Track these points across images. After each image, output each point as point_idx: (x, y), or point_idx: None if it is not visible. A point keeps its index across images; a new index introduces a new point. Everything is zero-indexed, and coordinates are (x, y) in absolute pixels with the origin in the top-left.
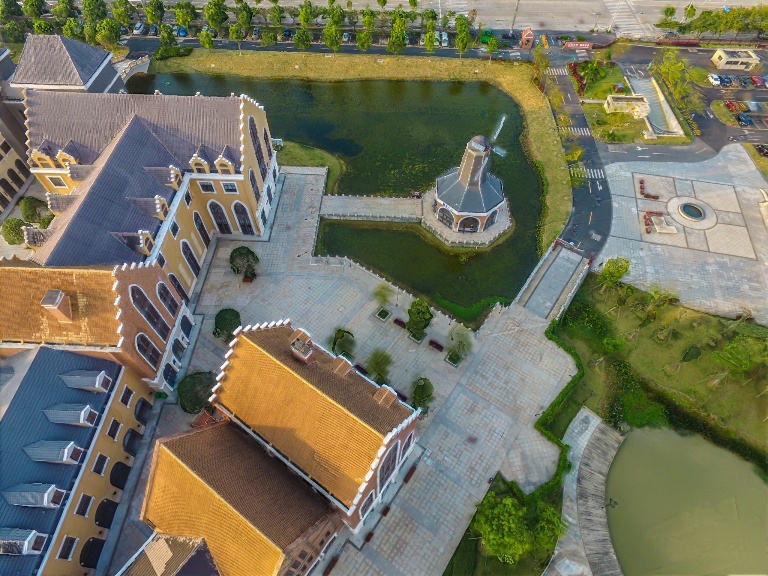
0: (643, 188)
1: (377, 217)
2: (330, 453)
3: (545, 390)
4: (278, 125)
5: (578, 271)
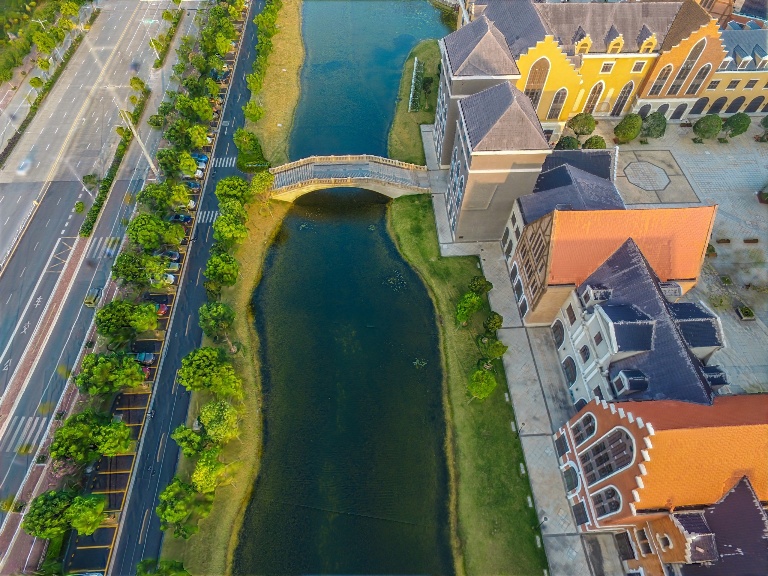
0: None
1: None
2: None
3: None
4: (380, 75)
5: None
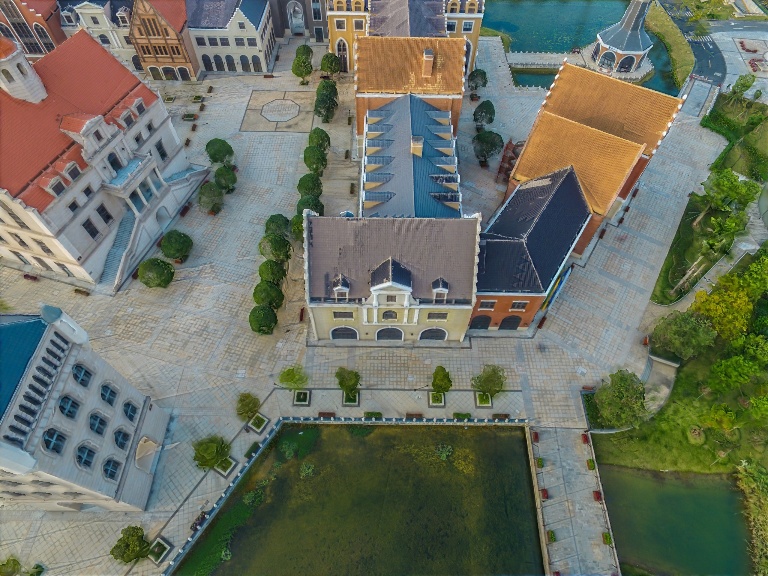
0: (744, 46)
1: (552, 65)
2: (637, 122)
3: (709, 153)
4: None
5: (712, 92)
